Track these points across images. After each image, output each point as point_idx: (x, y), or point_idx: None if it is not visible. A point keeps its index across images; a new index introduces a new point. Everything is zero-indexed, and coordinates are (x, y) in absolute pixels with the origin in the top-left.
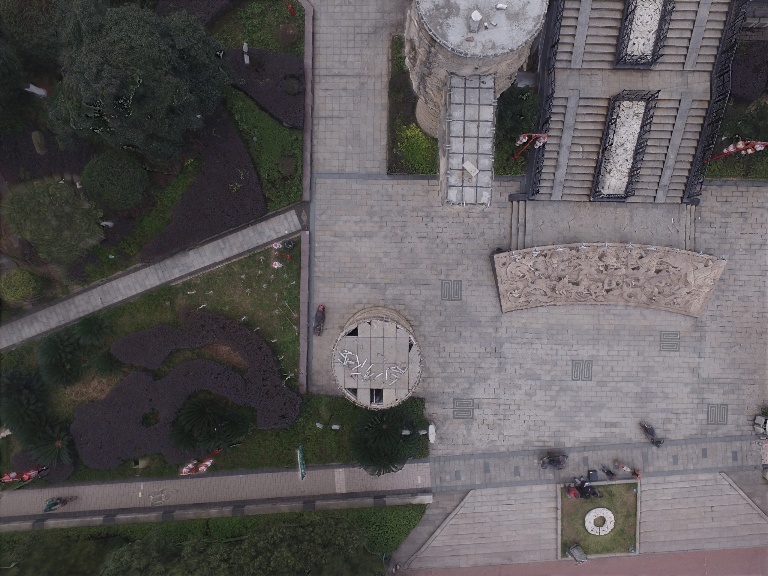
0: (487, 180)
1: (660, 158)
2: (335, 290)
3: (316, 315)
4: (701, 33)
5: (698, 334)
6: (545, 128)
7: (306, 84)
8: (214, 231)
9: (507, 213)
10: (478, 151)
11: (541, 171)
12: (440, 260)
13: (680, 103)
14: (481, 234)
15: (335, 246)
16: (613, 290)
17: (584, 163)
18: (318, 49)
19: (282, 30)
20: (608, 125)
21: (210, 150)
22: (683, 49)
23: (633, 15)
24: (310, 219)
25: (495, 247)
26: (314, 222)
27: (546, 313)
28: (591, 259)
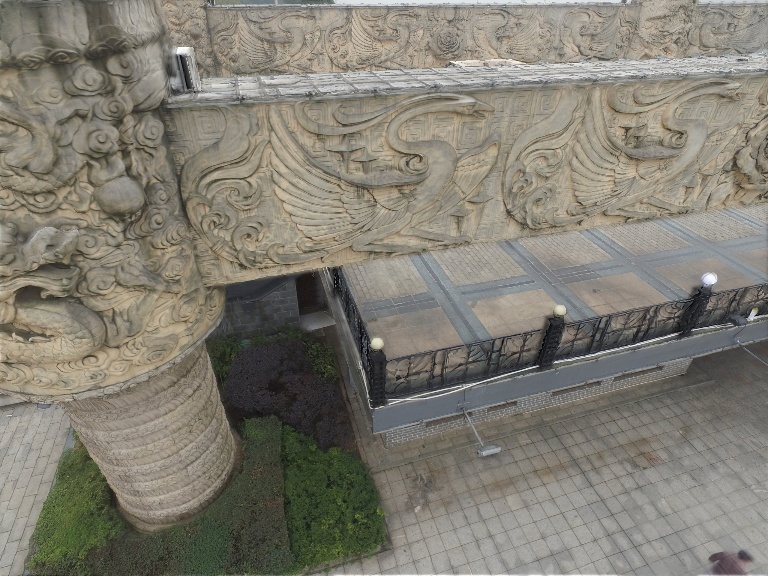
0: None
1: None
2: None
3: None
4: None
5: None
6: None
7: None
8: None
9: None
10: None
11: None
12: None
13: None
14: None
15: None
16: None
17: None
18: None
19: None
20: None
21: None
22: None
23: None
24: None
25: None
26: None
27: None
28: None
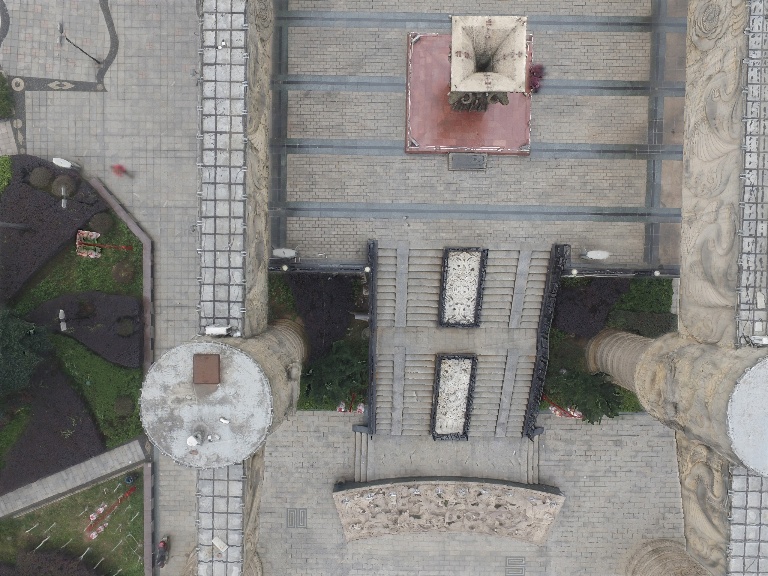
0: (237, 555)
1: (495, 401)
2: (180, 518)
3: (159, 548)
4: (521, 299)
5: (543, 559)
6: (375, 380)
7: (145, 318)
8: (51, 472)
9: (351, 443)
10: (228, 526)
11: (371, 422)
12: (285, 489)
13: (507, 359)
14: (325, 463)
15: (180, 475)
16: (455, 522)
17: (420, 405)
18: (159, 280)
19: (114, 272)
20: (437, 378)
21: (38, 401)
22: (506, 310)
23: (444, 294)
24: (154, 449)
25: (340, 476)
26: (158, 452)
27: (392, 540)
28: (430, 496)
